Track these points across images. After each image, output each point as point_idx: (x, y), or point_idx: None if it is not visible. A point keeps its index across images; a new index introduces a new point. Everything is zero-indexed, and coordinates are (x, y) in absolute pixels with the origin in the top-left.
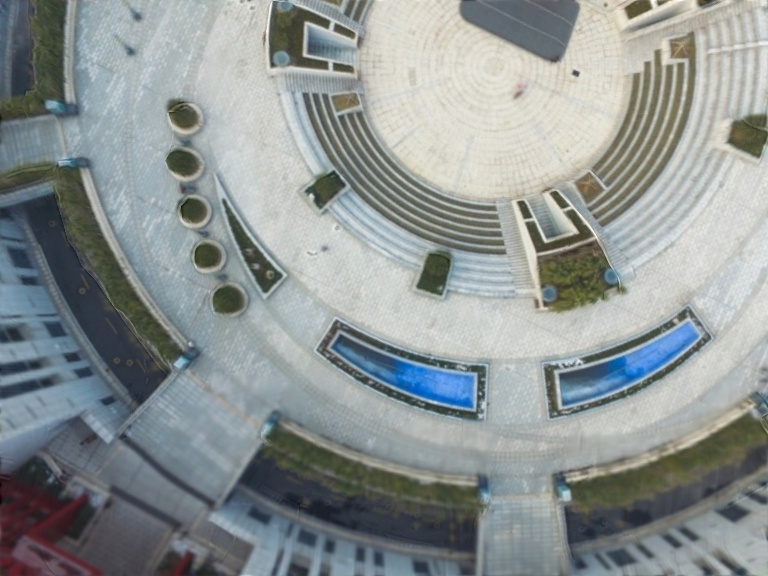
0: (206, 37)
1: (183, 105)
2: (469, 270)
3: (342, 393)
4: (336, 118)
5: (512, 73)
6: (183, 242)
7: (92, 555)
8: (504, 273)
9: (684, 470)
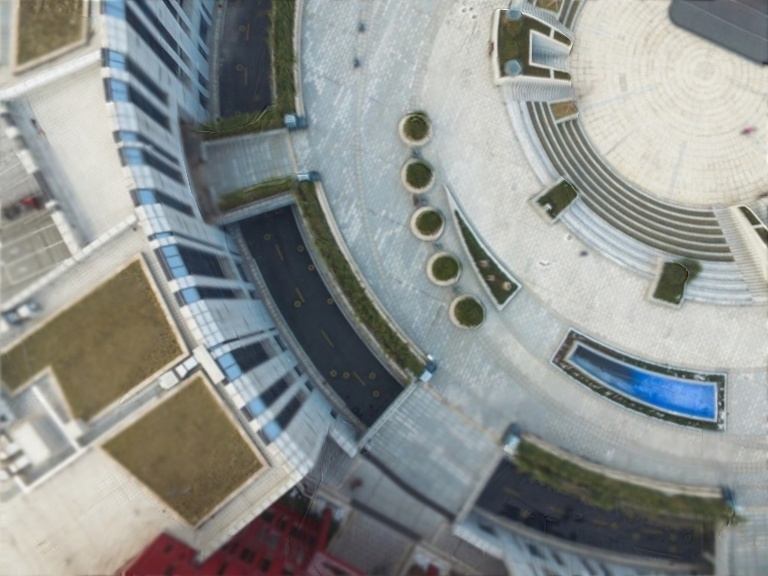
0: (430, 47)
1: (412, 116)
2: (702, 278)
3: (580, 404)
4: (555, 126)
5: (723, 77)
6: (415, 254)
7: (338, 570)
8: (737, 281)
9: None
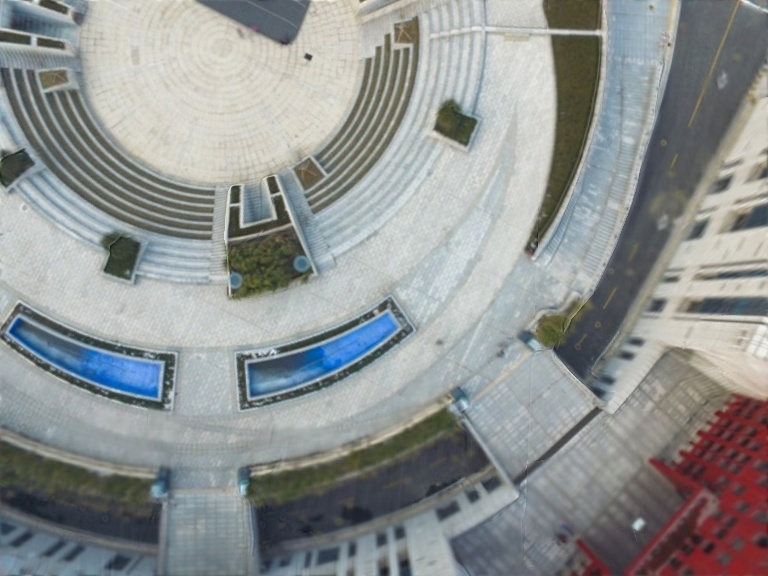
0: None
1: None
2: (165, 255)
3: (21, 379)
4: (42, 95)
5: (241, 55)
6: None
7: None
8: (202, 259)
9: (371, 466)
